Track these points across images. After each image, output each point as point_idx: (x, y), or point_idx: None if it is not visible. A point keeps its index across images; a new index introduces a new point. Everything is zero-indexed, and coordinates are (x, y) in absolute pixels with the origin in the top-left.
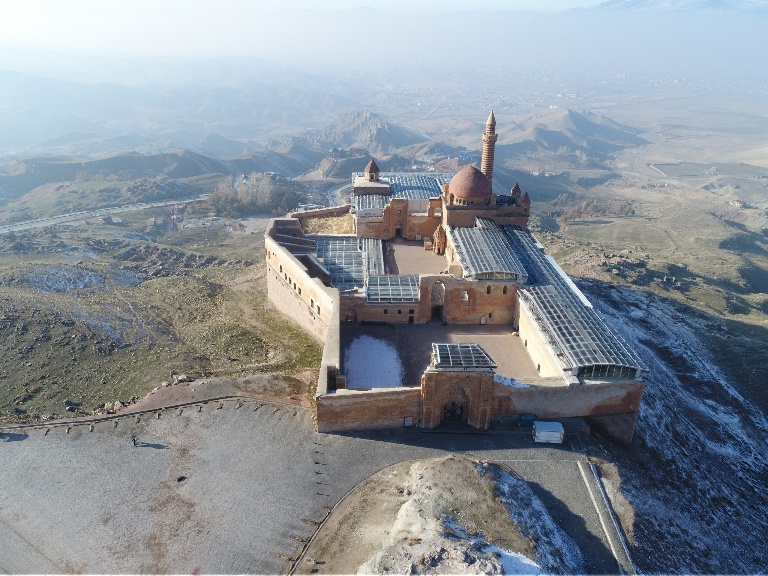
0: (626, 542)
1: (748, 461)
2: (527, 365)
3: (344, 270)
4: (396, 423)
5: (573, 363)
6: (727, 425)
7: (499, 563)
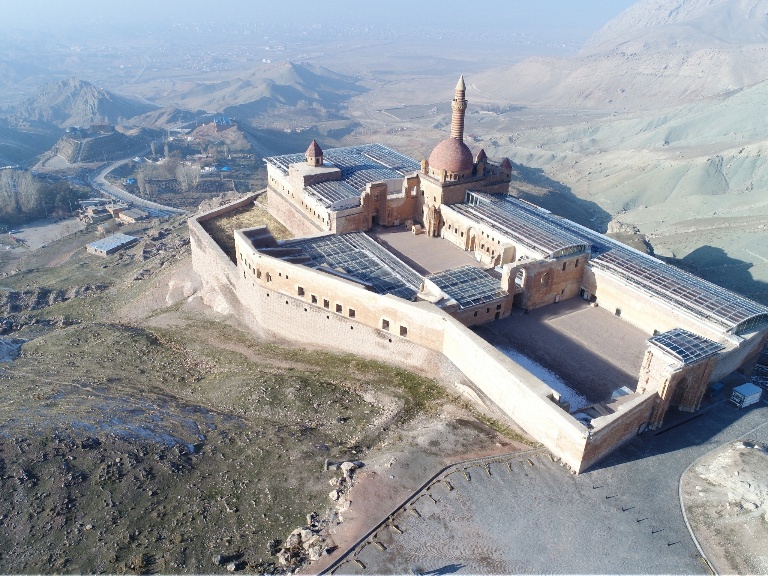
0: None
1: None
2: (639, 333)
3: (371, 276)
4: (632, 434)
5: (729, 322)
6: None
7: None
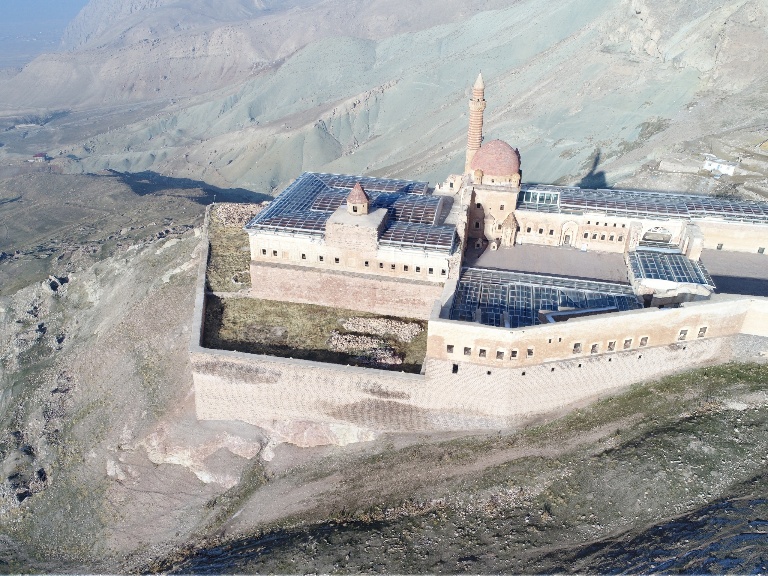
0: None
1: None
2: (750, 255)
3: (577, 302)
4: None
5: None
6: None
7: None
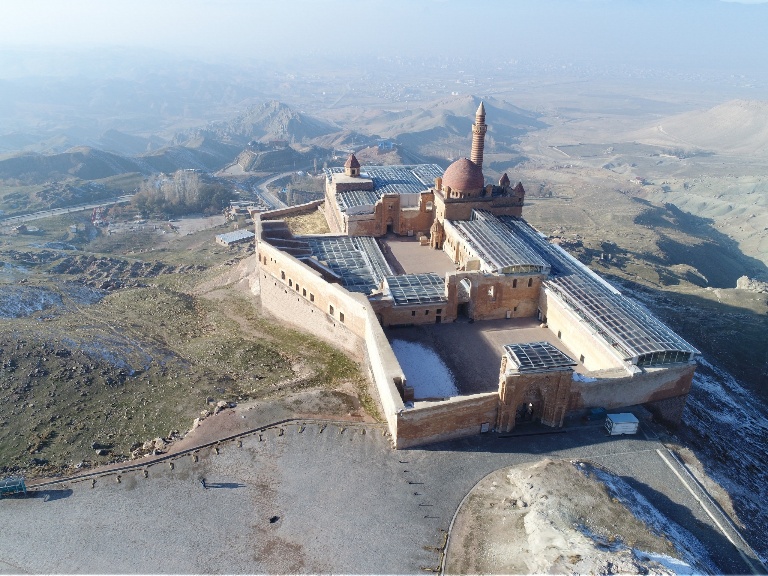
0: (735, 526)
1: (747, 426)
2: None
3: (350, 272)
4: (473, 431)
5: (632, 352)
6: (716, 393)
7: (670, 570)
